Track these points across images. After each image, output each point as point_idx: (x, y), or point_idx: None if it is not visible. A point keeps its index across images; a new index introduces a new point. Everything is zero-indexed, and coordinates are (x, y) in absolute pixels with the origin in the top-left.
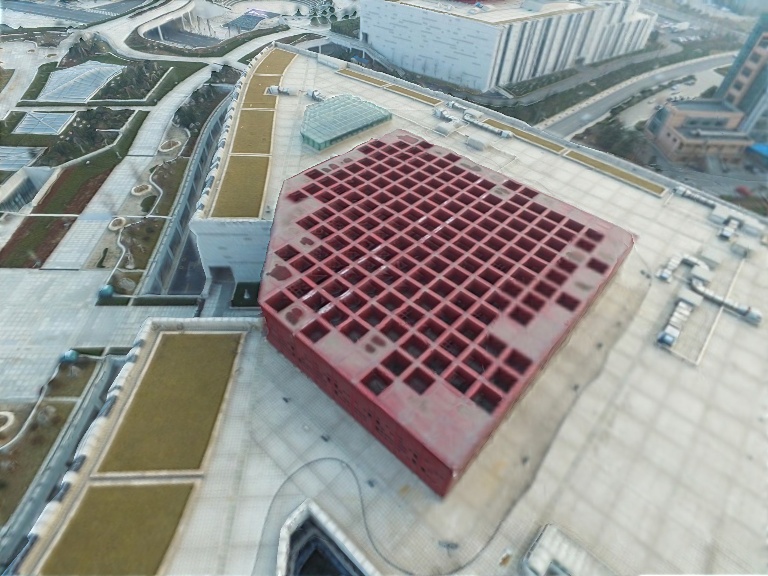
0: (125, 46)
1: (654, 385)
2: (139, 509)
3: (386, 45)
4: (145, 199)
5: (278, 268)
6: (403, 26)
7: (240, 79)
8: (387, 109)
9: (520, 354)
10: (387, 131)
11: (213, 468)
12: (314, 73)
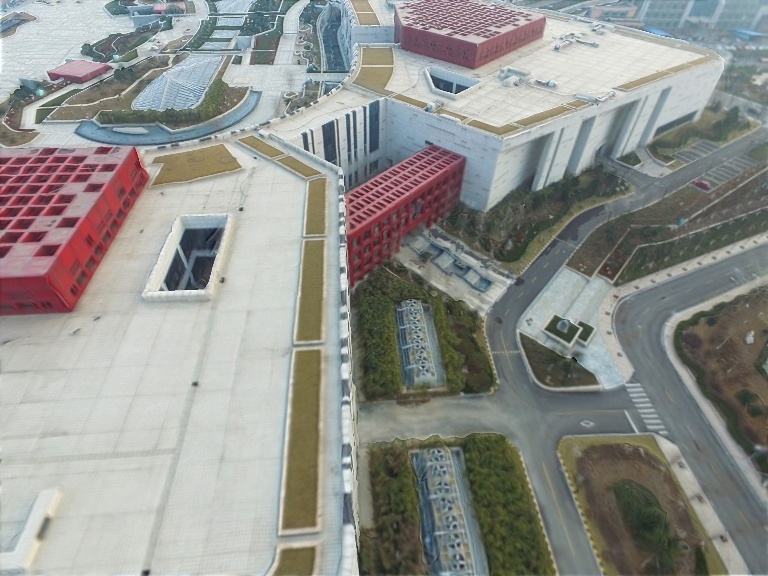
0: None
1: (550, 56)
2: (379, 69)
3: None
4: (305, 46)
5: (405, 20)
6: None
7: None
8: None
9: (497, 31)
10: None
11: (397, 66)
12: None
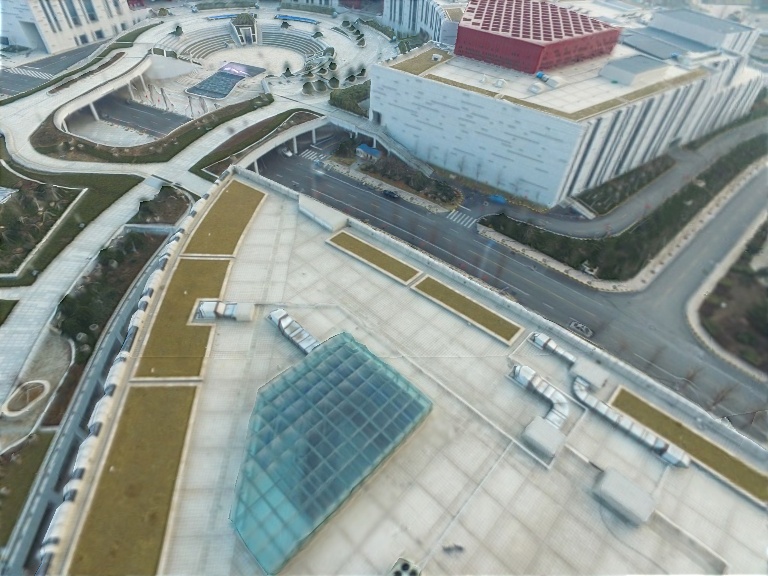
0: (28, 146)
1: None
2: None
3: (406, 130)
4: None
5: None
6: (432, 109)
7: (151, 280)
8: (420, 358)
9: None
10: (424, 452)
11: None
12: (290, 244)
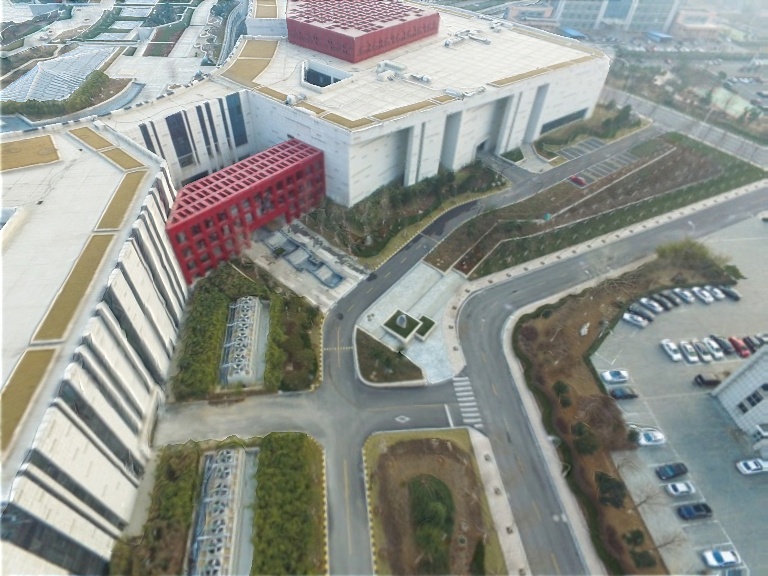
0: None
1: None
2: None
3: None
4: (208, 39)
5: (292, 12)
6: None
7: None
8: None
9: None
10: None
11: (277, 59)
12: None
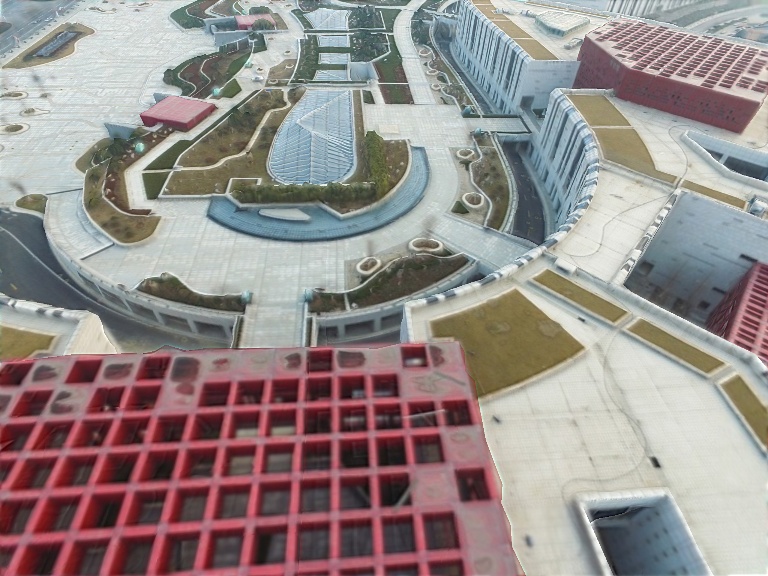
0: None
1: None
2: (619, 133)
3: None
4: (438, 77)
5: None
6: None
7: (472, 6)
8: None
9: None
10: (590, 30)
11: None
12: (510, 4)
